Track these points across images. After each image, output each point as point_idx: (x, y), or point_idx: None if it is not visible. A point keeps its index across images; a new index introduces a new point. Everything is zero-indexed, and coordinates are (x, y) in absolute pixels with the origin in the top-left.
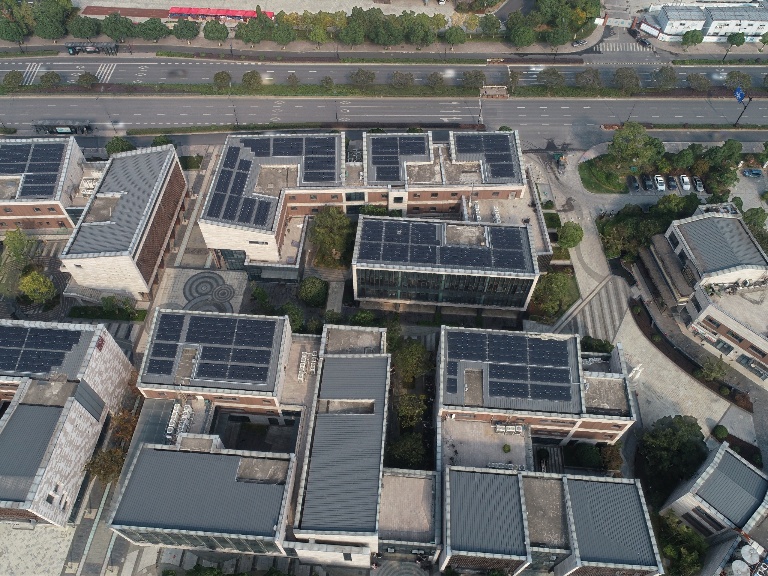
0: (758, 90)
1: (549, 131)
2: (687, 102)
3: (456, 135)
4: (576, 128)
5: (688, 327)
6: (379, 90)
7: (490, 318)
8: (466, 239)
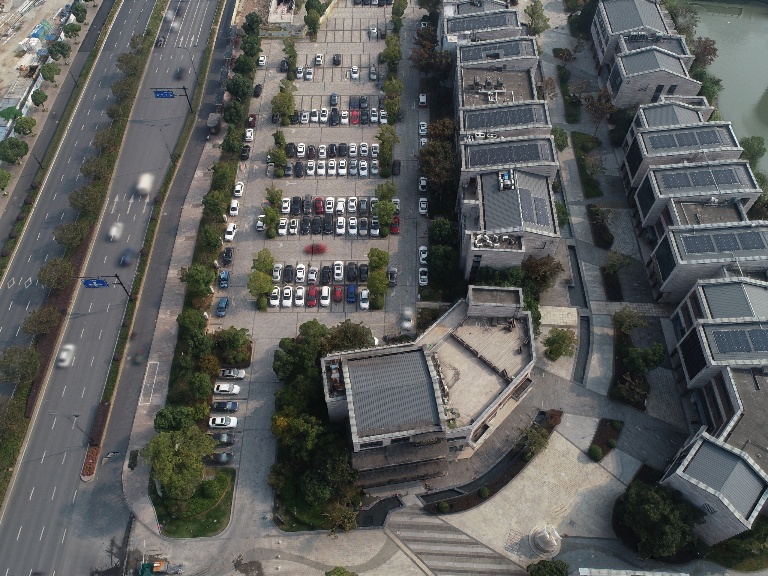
0: (72, 254)
1: (72, 575)
2: (65, 343)
3: None
4: (77, 523)
5: (464, 450)
6: None
7: None
8: None
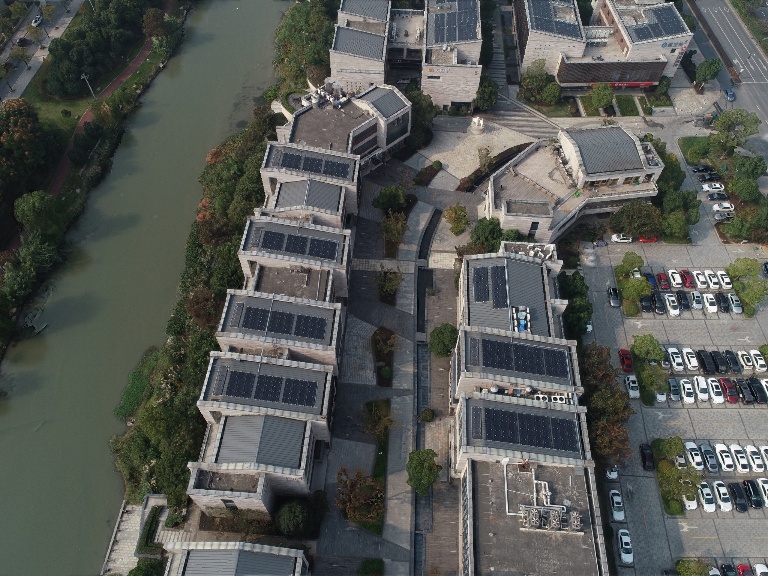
0: None
1: None
2: None
3: (672, 7)
4: None
5: None
6: (753, 23)
7: (517, 71)
8: (562, 16)
